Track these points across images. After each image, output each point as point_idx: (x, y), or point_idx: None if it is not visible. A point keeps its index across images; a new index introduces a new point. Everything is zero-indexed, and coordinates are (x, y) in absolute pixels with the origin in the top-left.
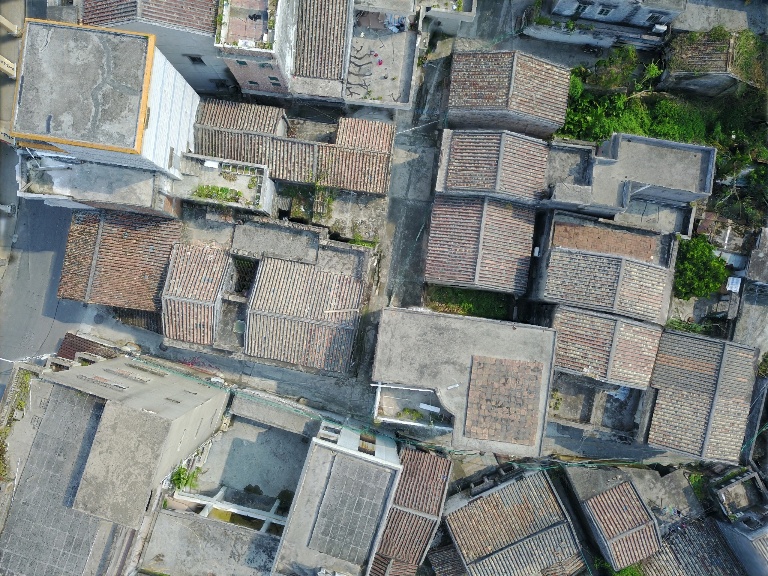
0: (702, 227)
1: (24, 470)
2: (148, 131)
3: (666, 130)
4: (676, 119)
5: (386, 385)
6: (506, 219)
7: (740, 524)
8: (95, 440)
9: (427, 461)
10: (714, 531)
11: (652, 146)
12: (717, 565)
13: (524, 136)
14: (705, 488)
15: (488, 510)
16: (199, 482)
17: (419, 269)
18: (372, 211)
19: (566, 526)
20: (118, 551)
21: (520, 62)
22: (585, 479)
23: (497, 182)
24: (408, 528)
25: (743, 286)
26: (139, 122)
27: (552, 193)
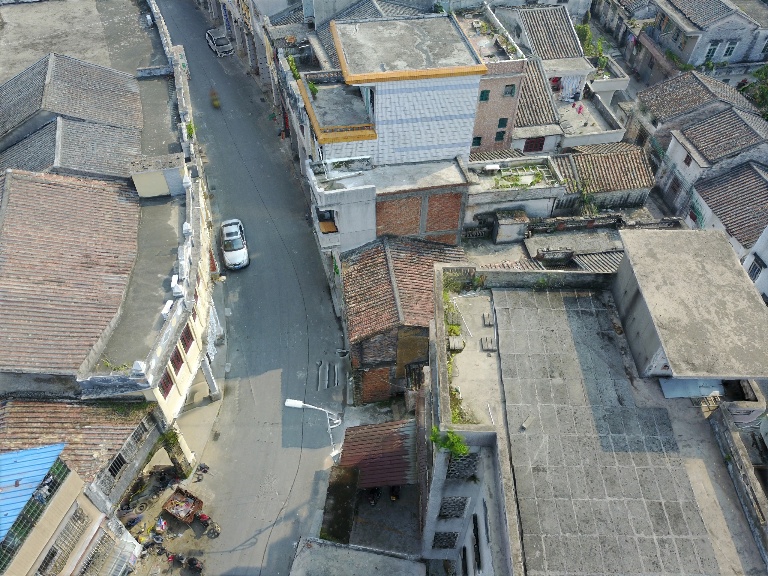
0: None
1: (508, 414)
2: None
3: None
4: None
5: None
6: None
7: None
8: (637, 275)
9: None
10: None
11: None
12: None
13: None
14: None
15: None
16: None
17: None
18: None
19: None
20: None
21: None
22: None
23: (760, 135)
24: None
25: None
26: None
27: None
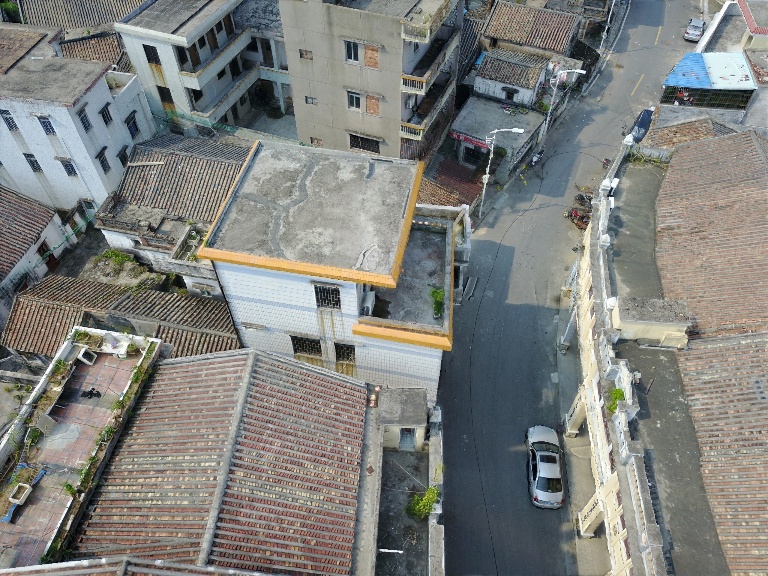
0: None
1: None
2: None
3: None
4: None
5: None
6: None
7: None
8: None
9: None
10: None
11: None
12: None
13: None
14: None
15: None
16: None
17: (77, 259)
18: None
19: None
20: None
21: None
22: None
23: None
24: None
25: None
26: (246, 163)
27: None
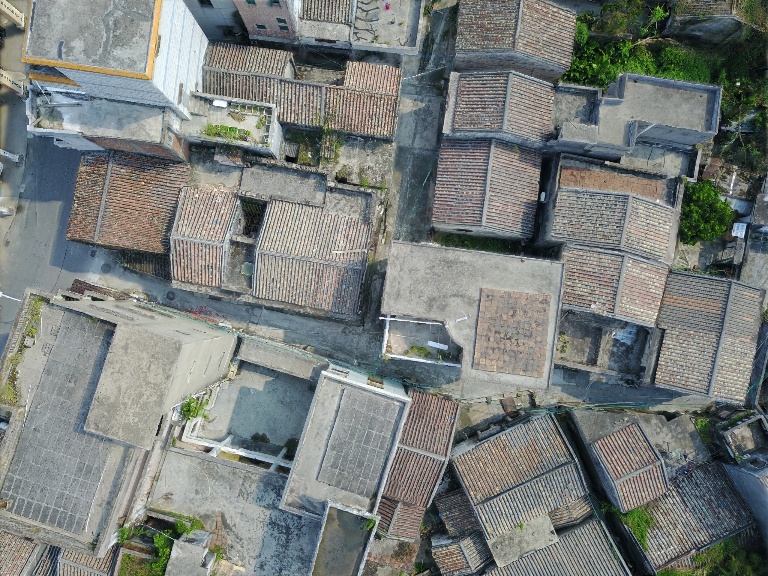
0: (707, 173)
1: (35, 396)
2: (158, 60)
3: (671, 76)
4: (681, 66)
5: (395, 318)
6: (513, 162)
7: (747, 464)
8: (107, 361)
9: (434, 403)
10: (721, 474)
11: (658, 87)
12: (724, 507)
13: (531, 77)
14: (711, 432)
15: (495, 452)
16: (206, 430)
17: (425, 218)
18: (379, 157)
19: (573, 467)
20: (129, 477)
21: (527, 4)
22: (592, 421)
23: (504, 122)
24: (416, 469)
25: (748, 231)
26: (150, 47)
27: (559, 134)
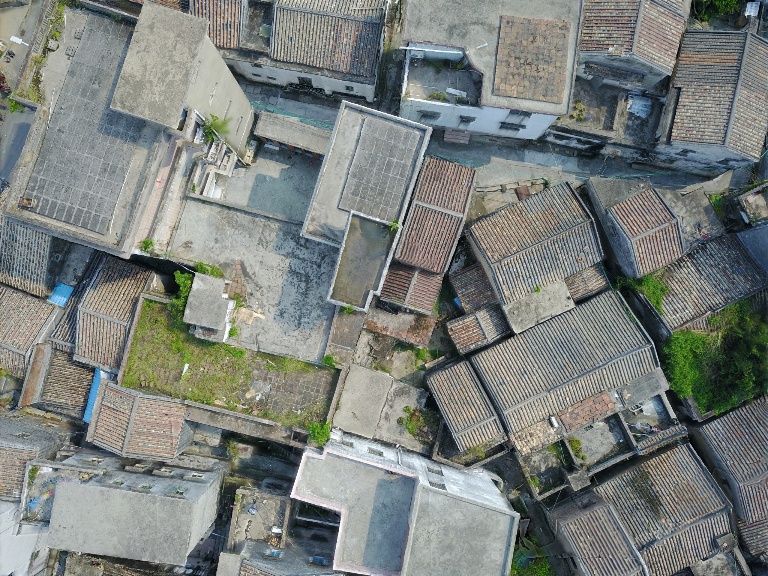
0: None
1: (59, 98)
2: None
3: None
4: None
5: (415, 47)
6: None
7: (762, 224)
8: (133, 40)
9: (452, 169)
10: (735, 244)
11: None
12: (738, 273)
13: None
14: (725, 207)
15: (512, 218)
16: None
17: None
18: None
19: (590, 228)
20: (153, 179)
21: None
22: (608, 188)
23: None
24: (433, 229)
25: (762, 8)
26: None
27: None
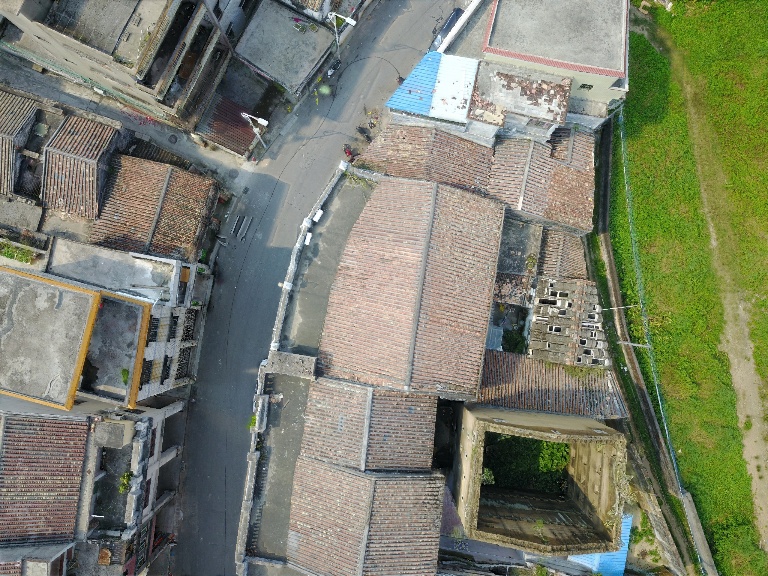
0: None
1: None
2: None
3: None
4: None
5: None
6: None
7: None
8: None
9: None
10: None
11: None
12: None
13: None
14: None
15: None
16: None
17: None
18: None
19: None
20: None
21: None
22: None
23: None
24: None
25: None
26: None
27: None
